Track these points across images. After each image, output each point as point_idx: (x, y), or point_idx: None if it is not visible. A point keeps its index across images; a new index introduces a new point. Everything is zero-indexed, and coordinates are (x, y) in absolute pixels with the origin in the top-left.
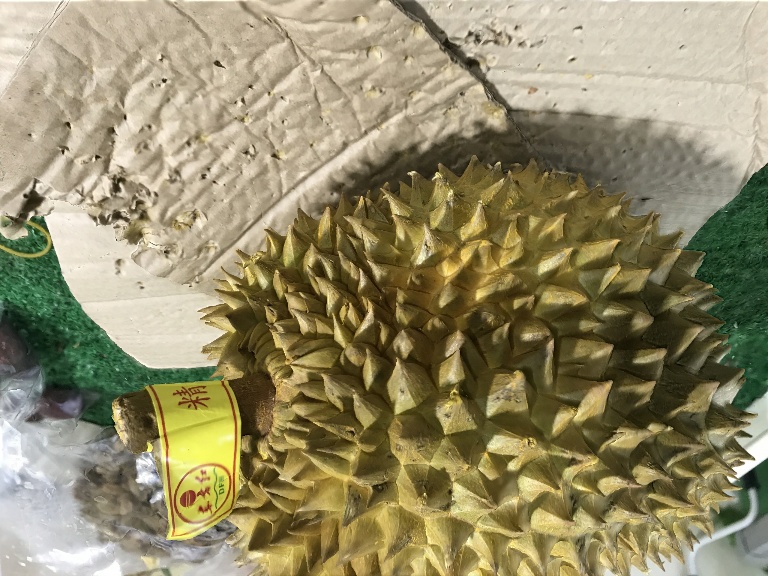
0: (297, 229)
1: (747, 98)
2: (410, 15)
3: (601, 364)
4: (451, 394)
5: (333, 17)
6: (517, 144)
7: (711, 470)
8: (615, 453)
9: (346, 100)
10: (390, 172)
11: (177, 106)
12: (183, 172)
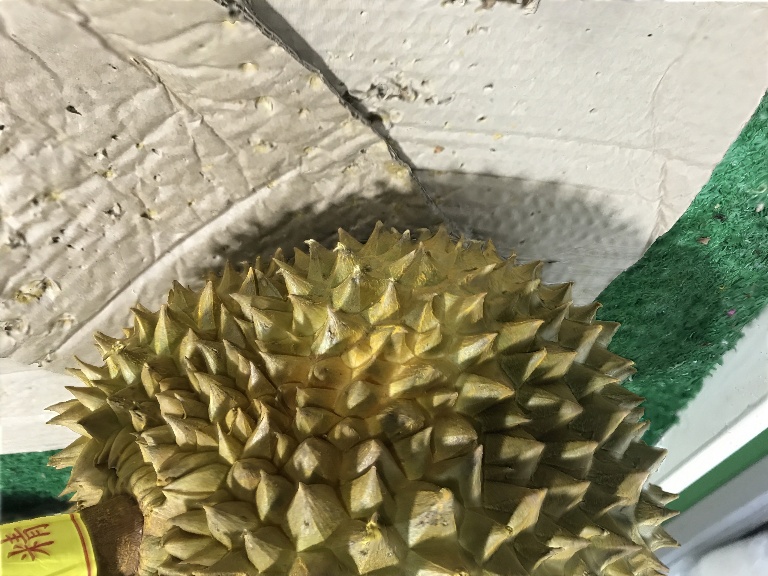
0: (172, 305)
1: (653, 164)
2: (306, 64)
3: (531, 464)
4: (368, 527)
5: (215, 62)
6: (422, 205)
7: (643, 567)
8: (549, 565)
9: (231, 155)
10: (282, 233)
11: (19, 158)
12: (28, 235)
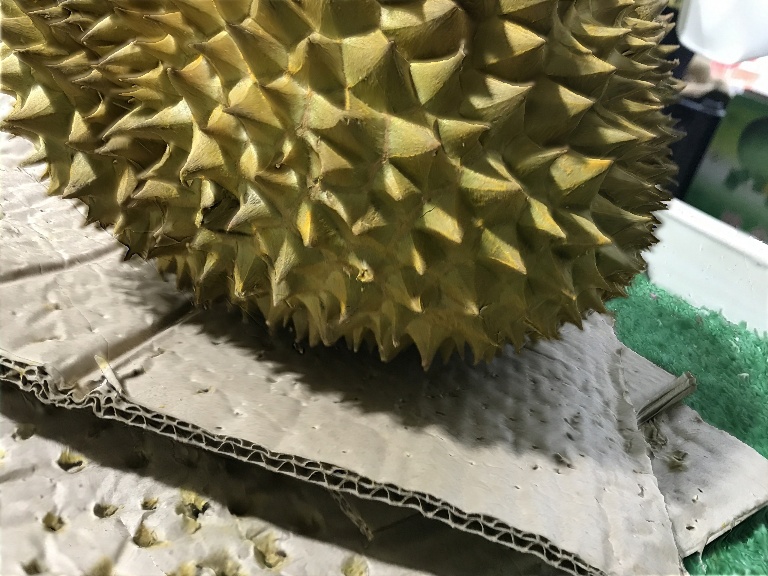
0: None
1: None
2: None
3: None
4: None
5: None
6: None
7: None
8: None
9: None
10: None
11: None
12: None
